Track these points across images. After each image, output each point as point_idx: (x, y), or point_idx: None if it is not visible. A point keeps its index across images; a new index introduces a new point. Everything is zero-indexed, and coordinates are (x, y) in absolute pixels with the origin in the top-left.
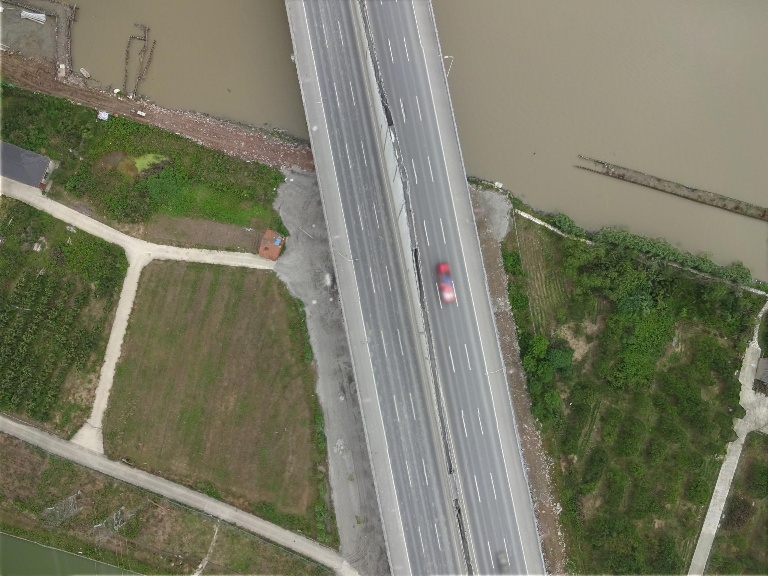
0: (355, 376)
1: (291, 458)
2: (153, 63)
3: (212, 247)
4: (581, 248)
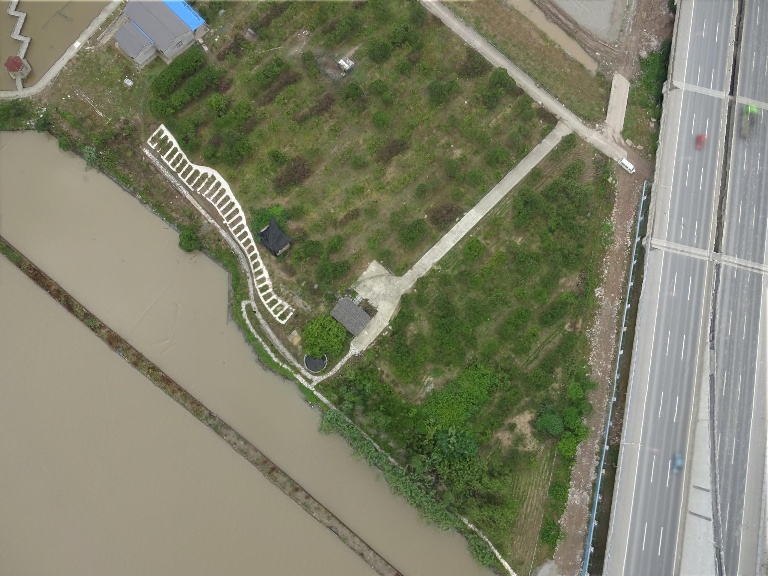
0: None
1: None
2: None
3: None
4: (494, 525)
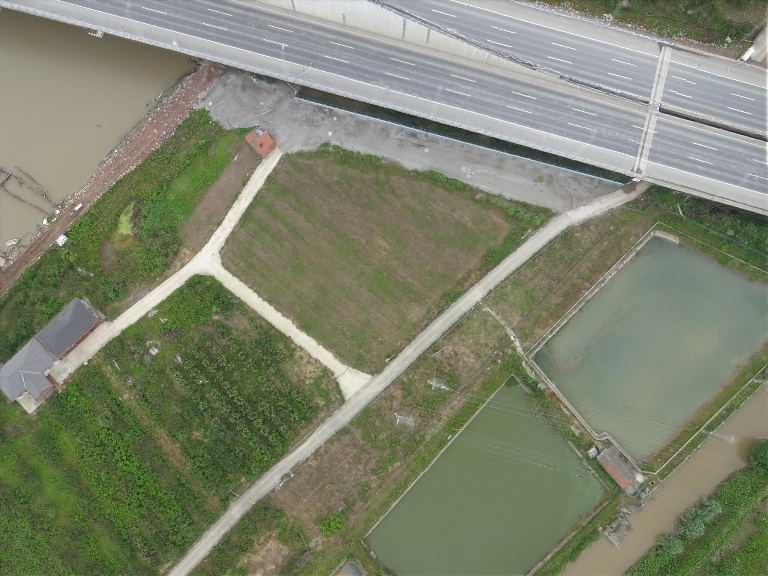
0: (413, 112)
1: (457, 215)
2: (36, 178)
3: (235, 196)
4: None
